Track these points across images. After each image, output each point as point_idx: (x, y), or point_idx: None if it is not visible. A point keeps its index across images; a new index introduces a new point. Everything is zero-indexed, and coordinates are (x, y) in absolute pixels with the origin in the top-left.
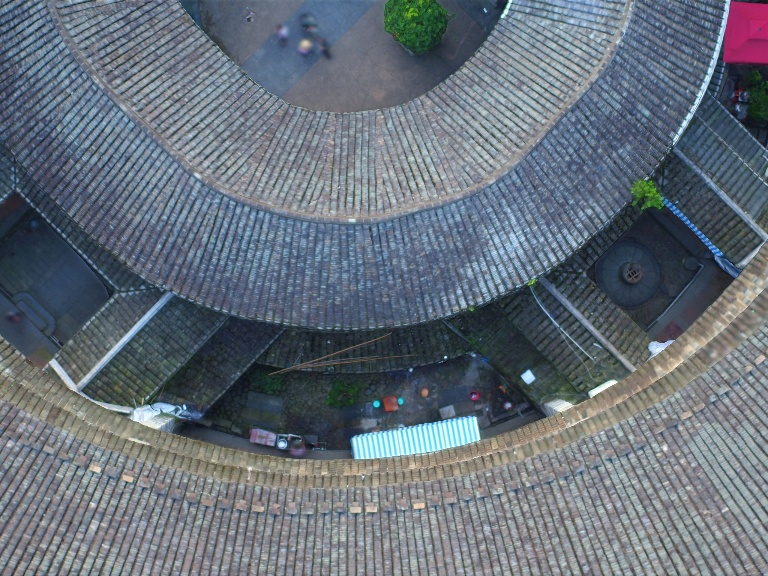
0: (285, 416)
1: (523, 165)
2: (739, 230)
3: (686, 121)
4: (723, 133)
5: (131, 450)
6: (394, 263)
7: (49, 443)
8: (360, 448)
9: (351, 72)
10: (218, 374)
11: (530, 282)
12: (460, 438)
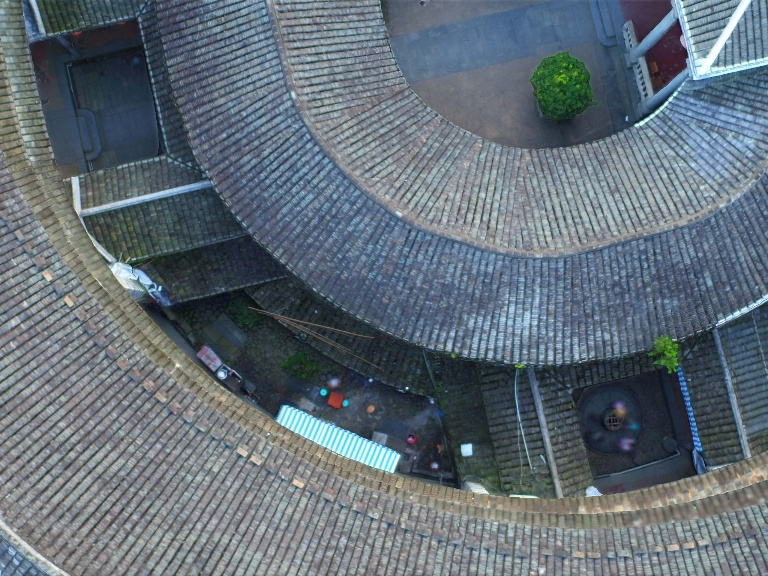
0: (240, 353)
1: (574, 259)
2: (729, 438)
3: (740, 312)
4: (767, 347)
5: (89, 285)
6: (412, 273)
7: (23, 230)
8: (285, 418)
9: (480, 99)
10: (206, 278)
11: (518, 364)
12: (375, 464)
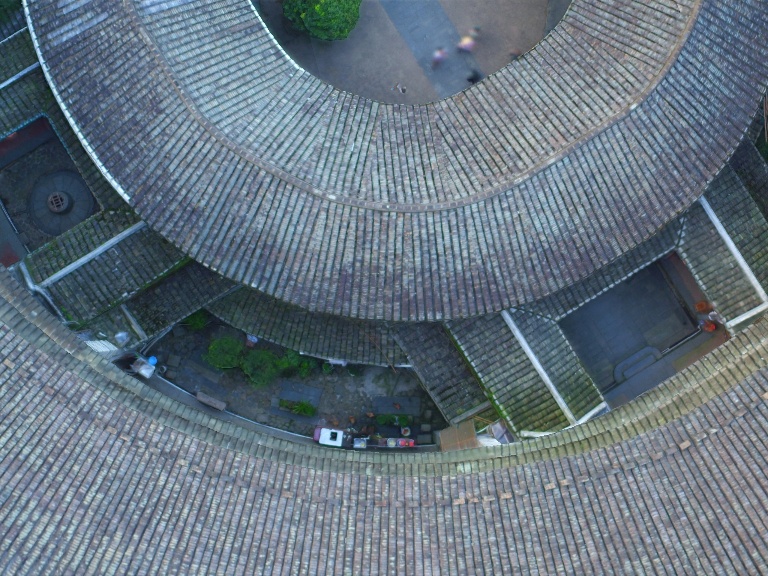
0: None
1: None
2: None
3: None
4: None
5: None
6: None
7: None
8: None
9: (478, 6)
10: (763, 184)
11: None
12: None
